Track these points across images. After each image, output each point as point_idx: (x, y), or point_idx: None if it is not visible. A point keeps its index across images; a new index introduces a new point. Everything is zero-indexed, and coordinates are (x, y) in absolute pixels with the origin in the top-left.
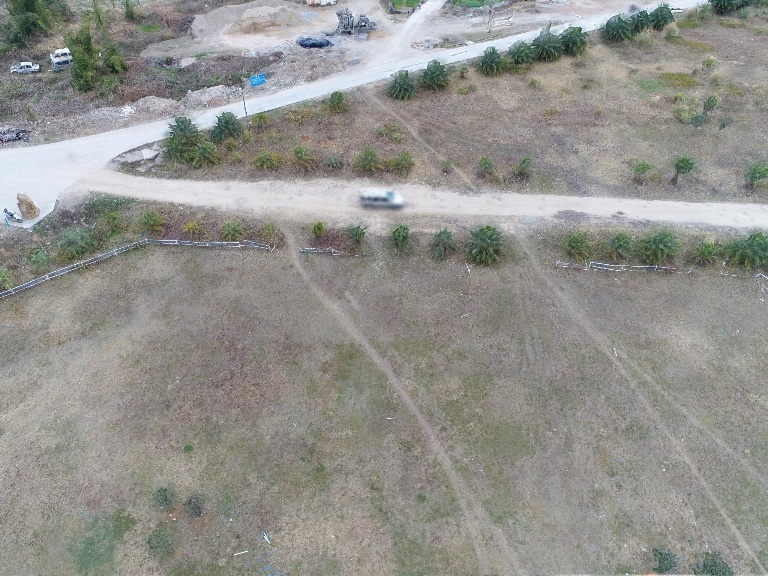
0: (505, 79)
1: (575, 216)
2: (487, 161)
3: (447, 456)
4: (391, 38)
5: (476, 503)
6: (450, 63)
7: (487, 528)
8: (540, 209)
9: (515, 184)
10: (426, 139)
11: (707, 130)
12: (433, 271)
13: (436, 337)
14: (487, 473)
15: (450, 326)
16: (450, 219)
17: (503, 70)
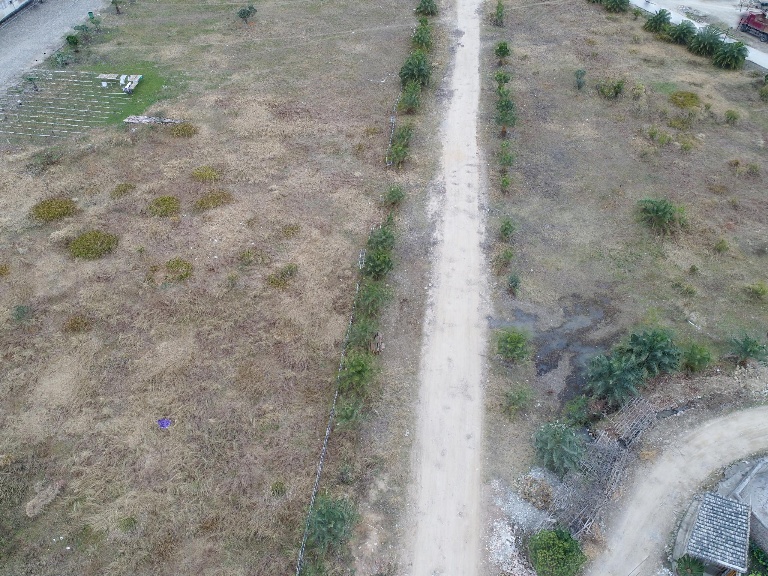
0: (643, 33)
1: (458, 34)
2: (500, 5)
3: (310, 0)
4: (694, 1)
5: (290, 3)
6: (655, 14)
7: (281, 4)
8: (465, 27)
9: (489, 22)
10: (537, 5)
11: (588, 95)
12: (412, 3)
13: (368, 1)
14: (301, 5)
15: (375, 4)
16: (453, 6)
17: (656, 31)
